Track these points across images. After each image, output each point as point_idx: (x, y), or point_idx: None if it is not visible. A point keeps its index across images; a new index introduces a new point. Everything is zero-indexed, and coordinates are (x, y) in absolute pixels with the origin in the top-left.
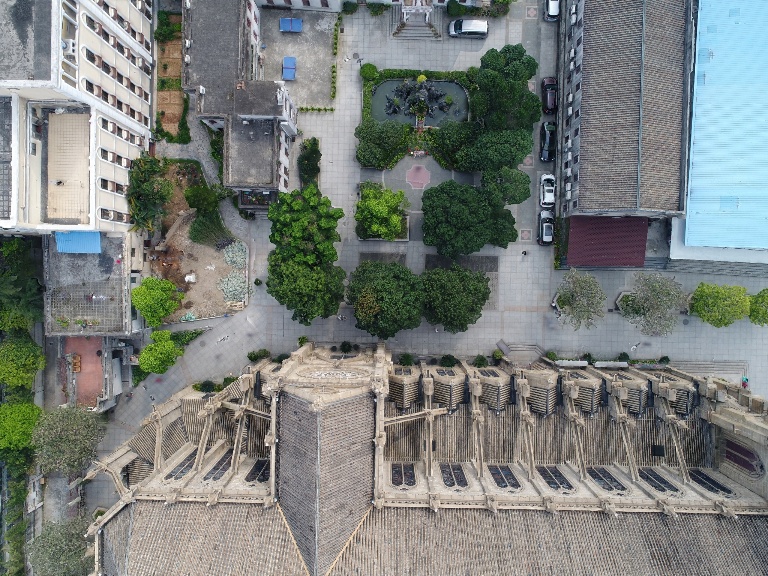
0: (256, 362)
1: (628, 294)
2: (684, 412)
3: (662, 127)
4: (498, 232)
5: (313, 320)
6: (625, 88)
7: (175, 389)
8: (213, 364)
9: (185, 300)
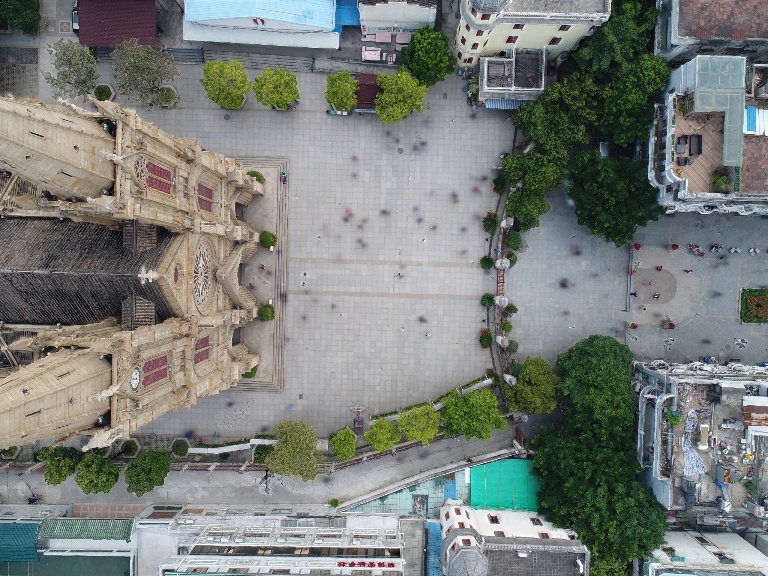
0: None
1: (166, 87)
2: None
3: None
4: (6, 9)
5: None
6: None
7: None
8: None
9: None
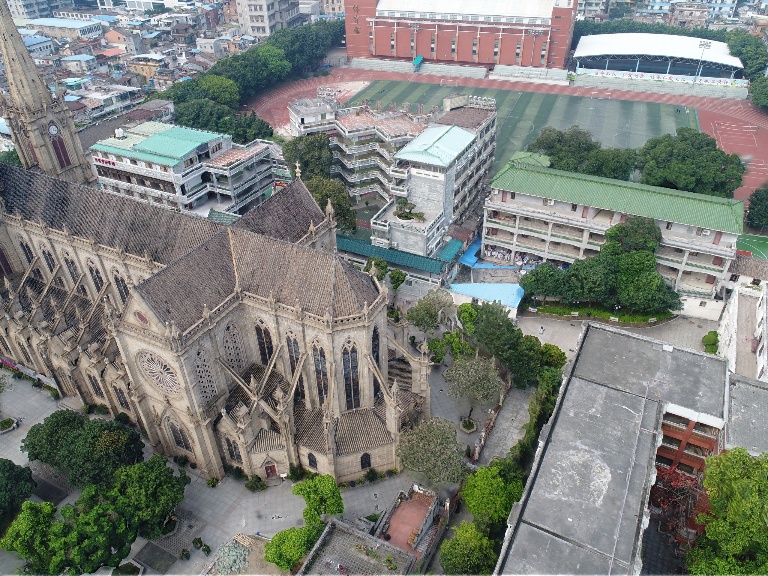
0: (264, 484)
1: None
2: (6, 303)
3: None
4: None
5: (191, 498)
6: None
7: (350, 495)
8: (303, 500)
9: (287, 569)
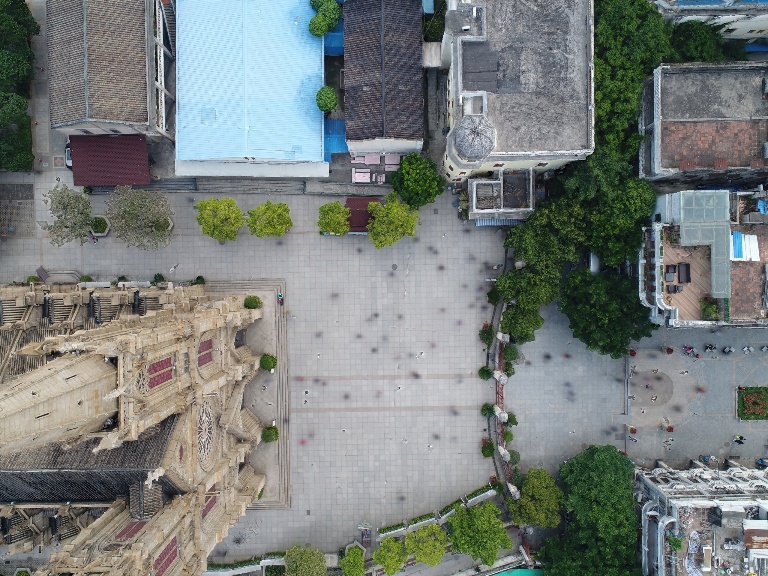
0: None
1: None
2: None
3: (117, 39)
4: (0, 155)
5: None
6: (73, 2)
7: None
8: None
9: None
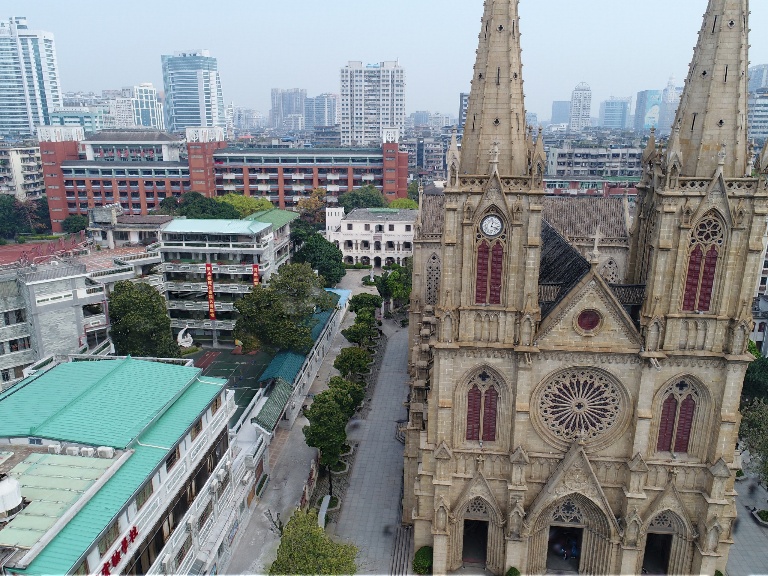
0: None
1: None
2: None
3: None
4: None
5: None
6: None
7: None
8: None
9: None
